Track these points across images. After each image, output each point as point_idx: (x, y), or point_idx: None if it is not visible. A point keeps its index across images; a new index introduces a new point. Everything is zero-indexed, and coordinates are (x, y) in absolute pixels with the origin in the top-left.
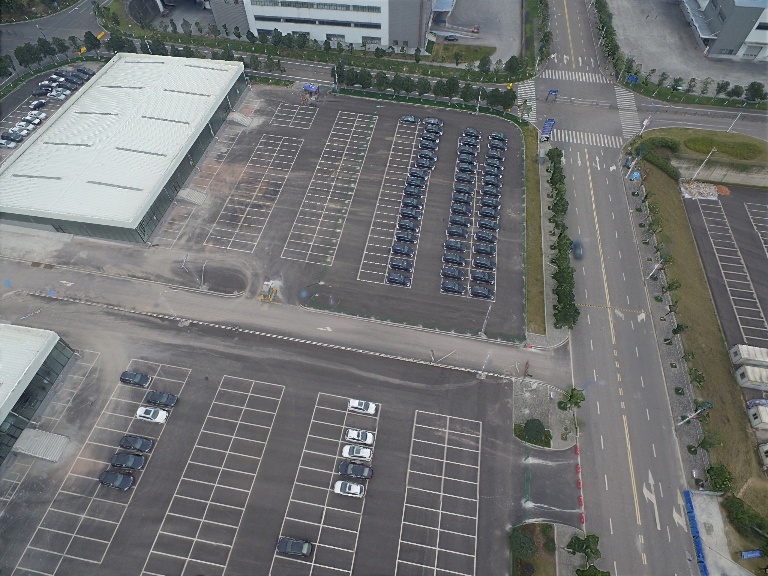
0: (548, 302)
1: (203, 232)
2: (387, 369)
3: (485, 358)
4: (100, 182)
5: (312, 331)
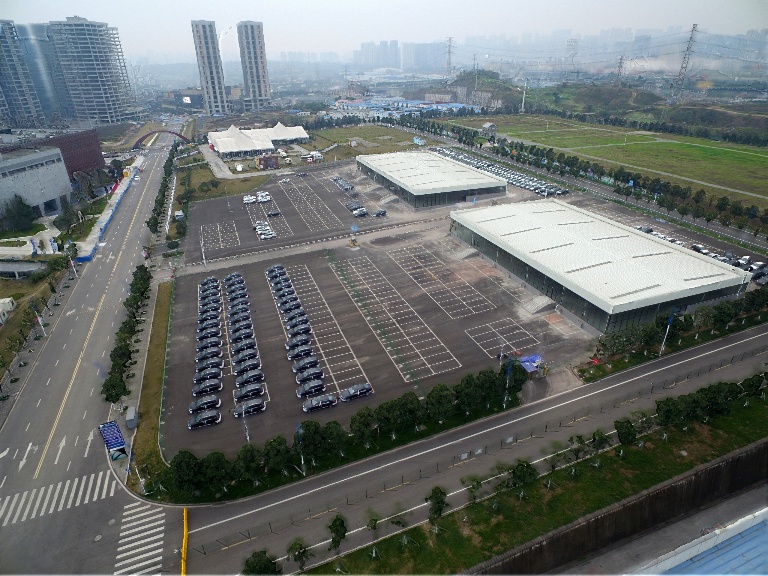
0: (153, 298)
1: (430, 248)
2: (263, 248)
3: (203, 267)
4: (508, 217)
5: (315, 245)
